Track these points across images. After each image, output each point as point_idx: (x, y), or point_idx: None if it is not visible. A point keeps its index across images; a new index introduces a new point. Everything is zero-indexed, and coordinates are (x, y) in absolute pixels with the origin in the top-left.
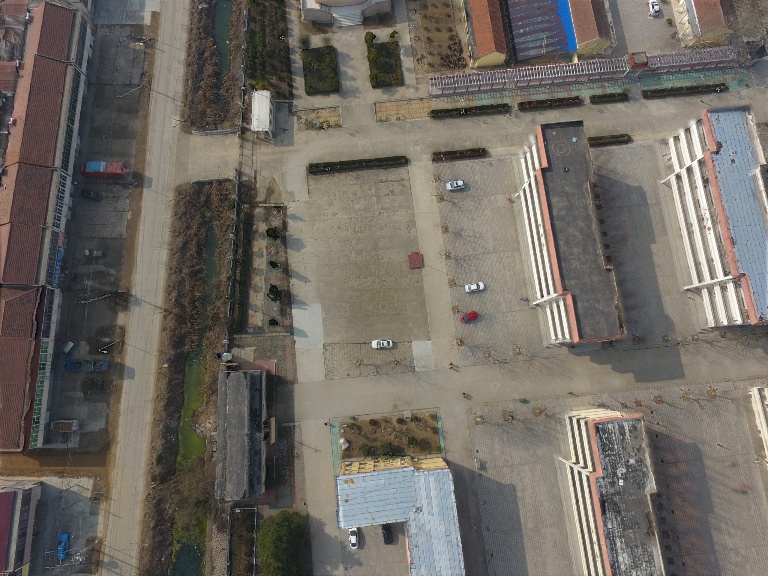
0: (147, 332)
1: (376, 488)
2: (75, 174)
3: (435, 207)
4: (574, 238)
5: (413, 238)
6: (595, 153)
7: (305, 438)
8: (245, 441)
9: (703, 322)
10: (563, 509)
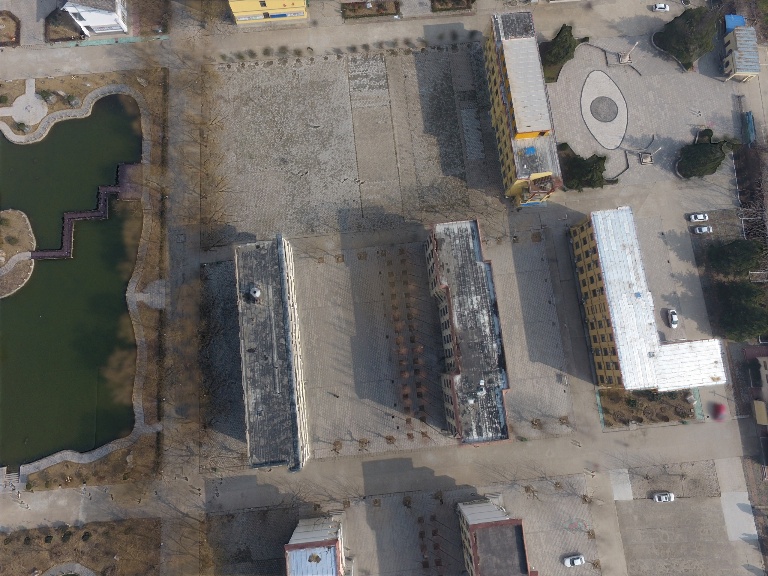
0: None
1: (691, 373)
2: None
3: None
4: None
5: None
6: None
7: (726, 404)
8: None
9: None
10: None
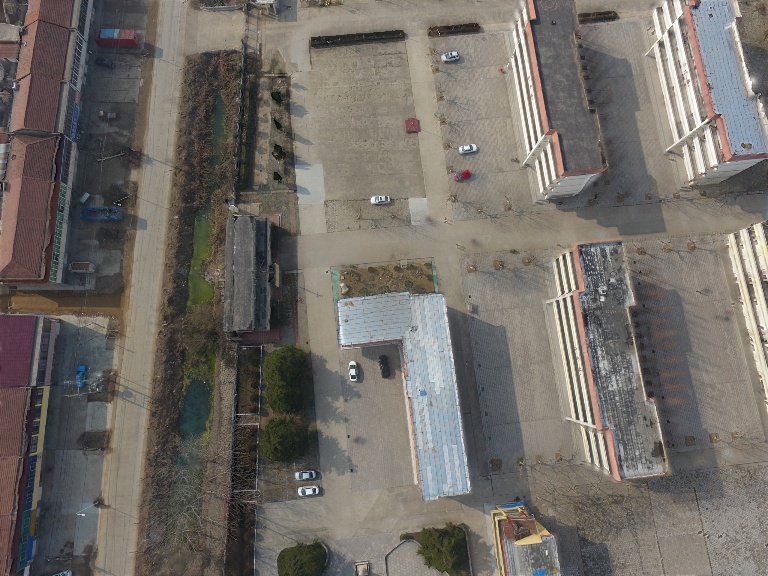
0: (158, 187)
1: (374, 310)
2: (90, 41)
3: (431, 77)
4: (560, 84)
5: (410, 105)
6: (583, 29)
7: (307, 284)
8: (251, 277)
9: (684, 179)
10: (550, 348)
